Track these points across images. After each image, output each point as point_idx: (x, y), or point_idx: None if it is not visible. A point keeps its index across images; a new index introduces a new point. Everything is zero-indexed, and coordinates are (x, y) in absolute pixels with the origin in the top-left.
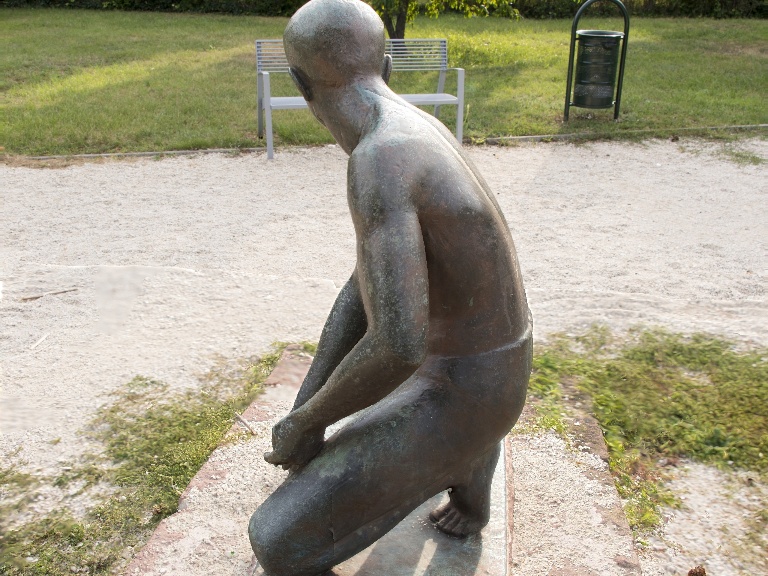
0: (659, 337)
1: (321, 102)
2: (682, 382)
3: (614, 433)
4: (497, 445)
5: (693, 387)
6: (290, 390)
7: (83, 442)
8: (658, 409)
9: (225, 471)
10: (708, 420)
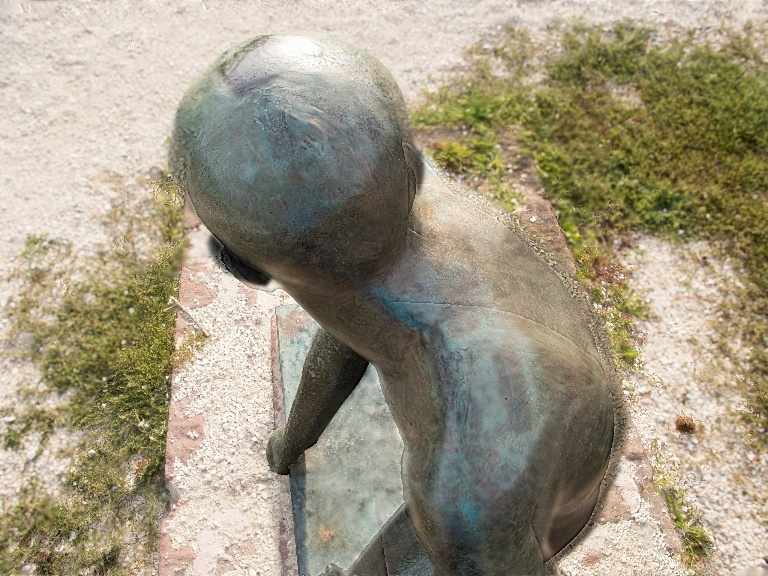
0: (581, 37)
1: (302, 300)
2: (615, 109)
3: (567, 214)
4: None
5: (627, 115)
6: None
7: (10, 369)
8: (601, 162)
9: (200, 421)
10: (651, 170)
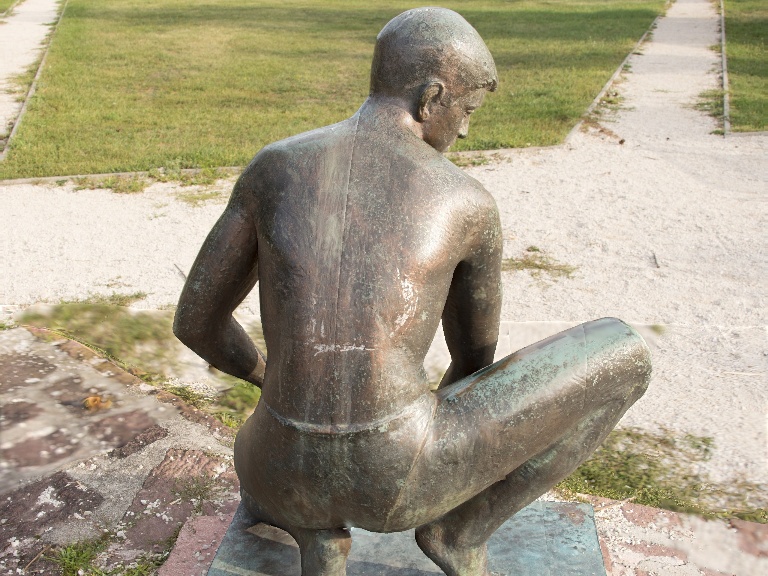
0: None
1: None
2: None
3: None
4: (318, 543)
5: None
6: (729, 541)
7: None
8: None
9: None
10: None
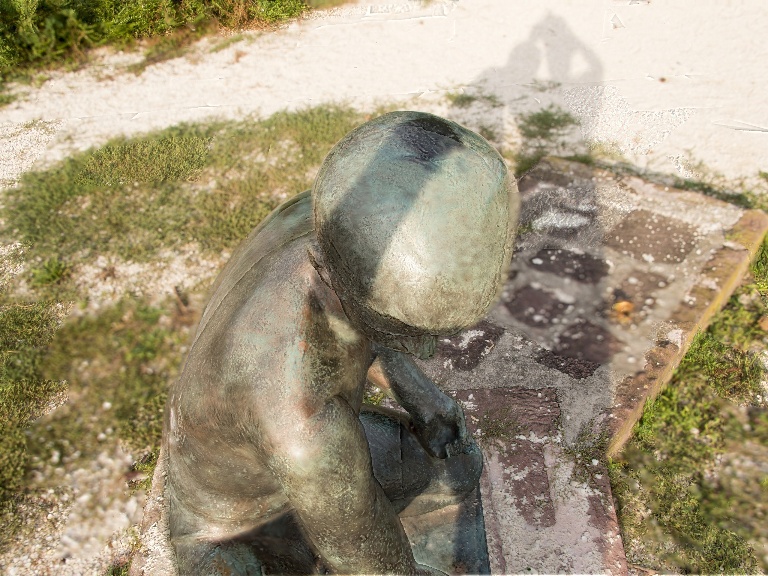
0: None
1: None
2: None
3: None
4: None
5: None
6: None
7: None
8: None
9: None
10: None
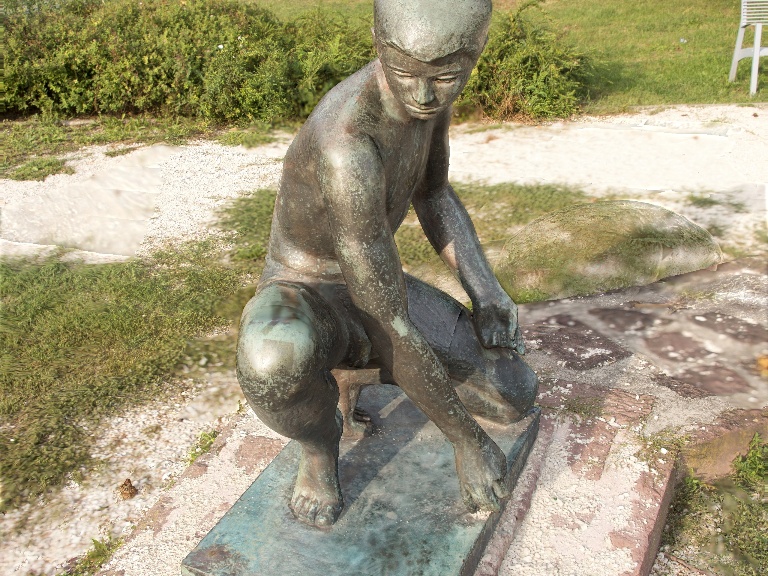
0: None
1: None
2: None
3: None
4: None
5: None
6: None
7: None
8: None
9: None
10: None
